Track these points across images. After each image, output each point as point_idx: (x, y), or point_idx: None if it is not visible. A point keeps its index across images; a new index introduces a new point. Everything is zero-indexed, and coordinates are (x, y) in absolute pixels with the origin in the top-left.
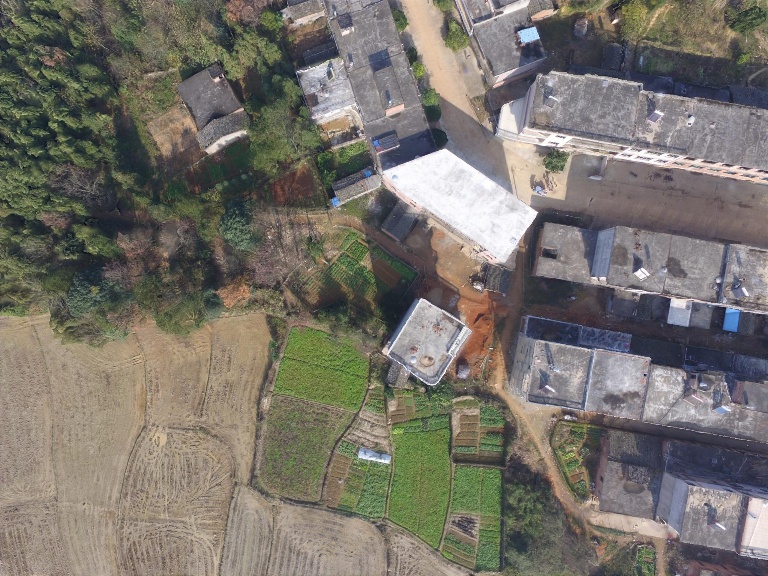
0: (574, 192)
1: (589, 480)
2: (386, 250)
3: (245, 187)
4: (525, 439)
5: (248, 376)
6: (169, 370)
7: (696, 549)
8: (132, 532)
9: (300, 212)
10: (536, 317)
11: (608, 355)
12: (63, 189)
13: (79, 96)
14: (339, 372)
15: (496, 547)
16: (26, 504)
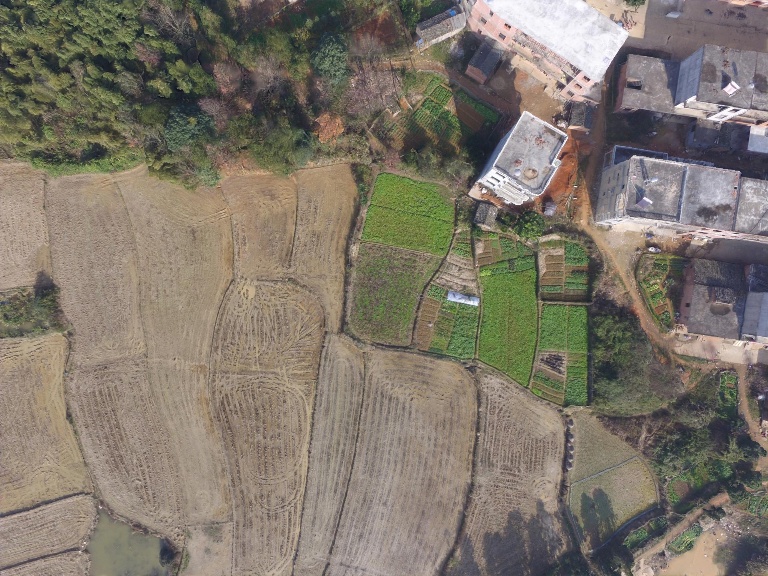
0: (652, 30)
1: (673, 311)
2: (471, 92)
3: (331, 29)
4: (610, 273)
5: (335, 226)
6: (255, 223)
7: None
8: (224, 385)
9: (383, 59)
10: (623, 146)
11: (700, 169)
12: (155, 23)
13: None
14: (426, 217)
15: (583, 382)
16: (115, 362)
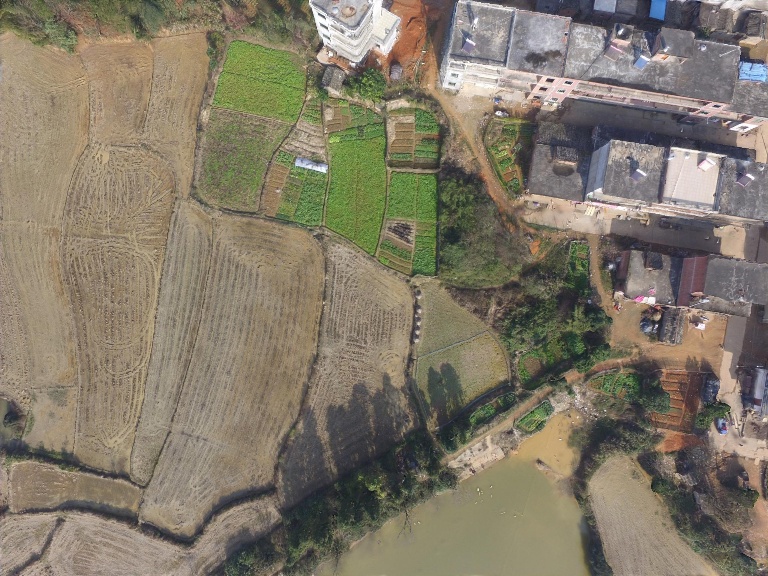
0: None
1: (522, 178)
2: None
3: None
4: (458, 139)
5: (189, 94)
6: (112, 90)
7: (629, 241)
8: (75, 248)
9: None
10: None
11: (529, 15)
12: None
13: None
14: (276, 84)
15: (432, 252)
16: None
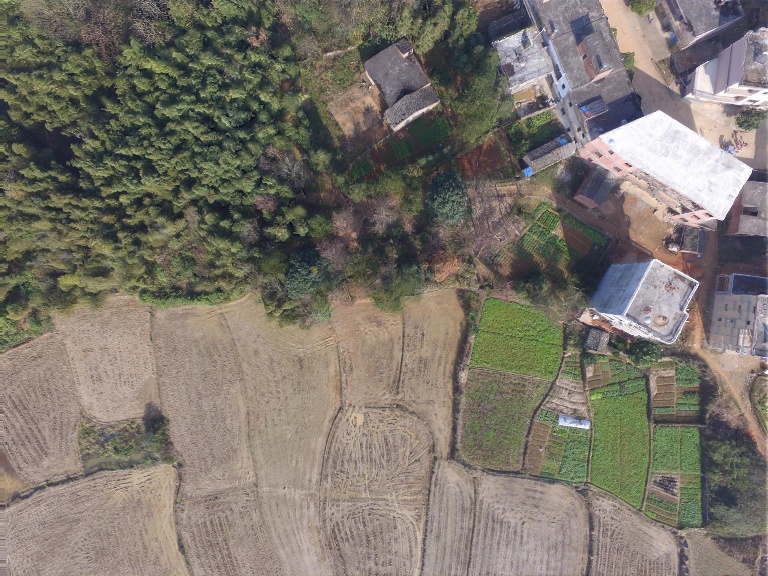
0: (763, 150)
1: None
2: (580, 218)
3: (440, 162)
4: (725, 396)
5: (441, 351)
6: (362, 350)
7: None
8: (334, 513)
9: (488, 185)
10: (741, 274)
11: None
12: (272, 171)
13: (278, 77)
14: (534, 342)
15: (697, 504)
16: (225, 492)
